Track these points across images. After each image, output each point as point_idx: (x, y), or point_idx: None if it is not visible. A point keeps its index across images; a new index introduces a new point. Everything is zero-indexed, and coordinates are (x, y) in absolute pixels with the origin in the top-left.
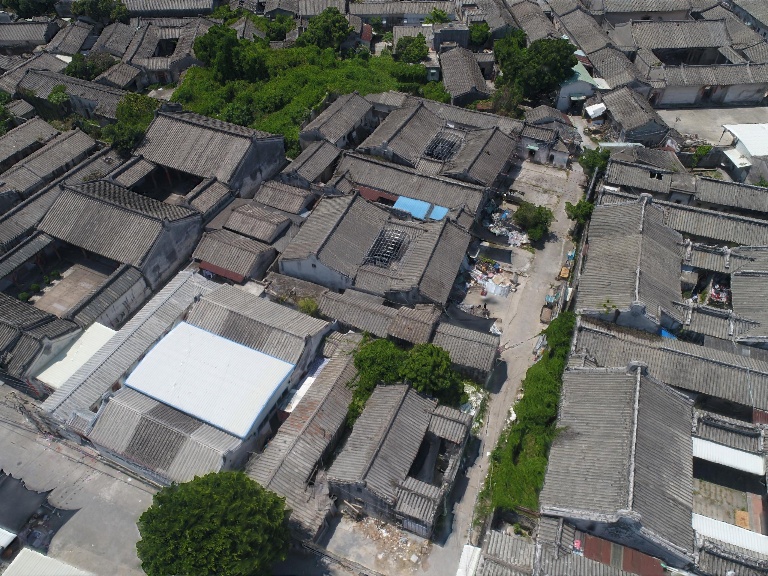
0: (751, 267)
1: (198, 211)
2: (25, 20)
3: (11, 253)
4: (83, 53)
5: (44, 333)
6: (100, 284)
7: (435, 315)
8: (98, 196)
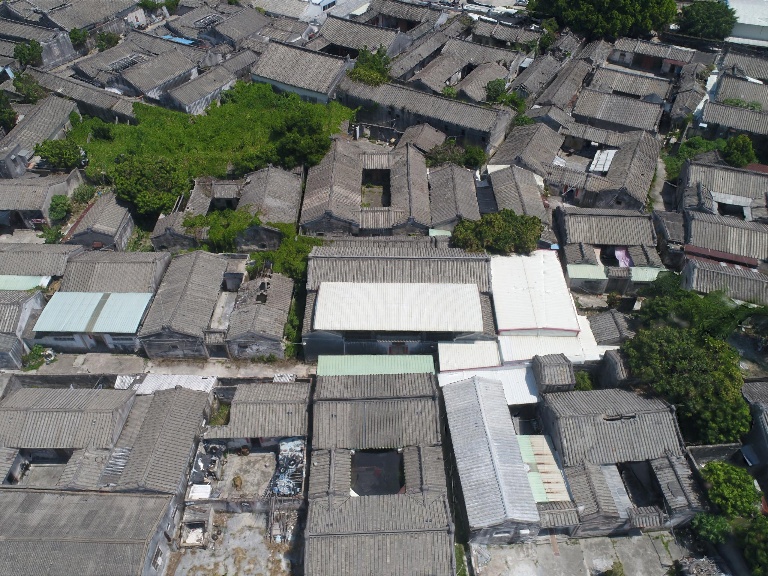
0: (30, 8)
1: (315, 36)
2: (639, 264)
3: (417, 27)
4: (485, 184)
5: (379, 2)
6: (364, 21)
7: (202, 2)
8: (376, 33)
